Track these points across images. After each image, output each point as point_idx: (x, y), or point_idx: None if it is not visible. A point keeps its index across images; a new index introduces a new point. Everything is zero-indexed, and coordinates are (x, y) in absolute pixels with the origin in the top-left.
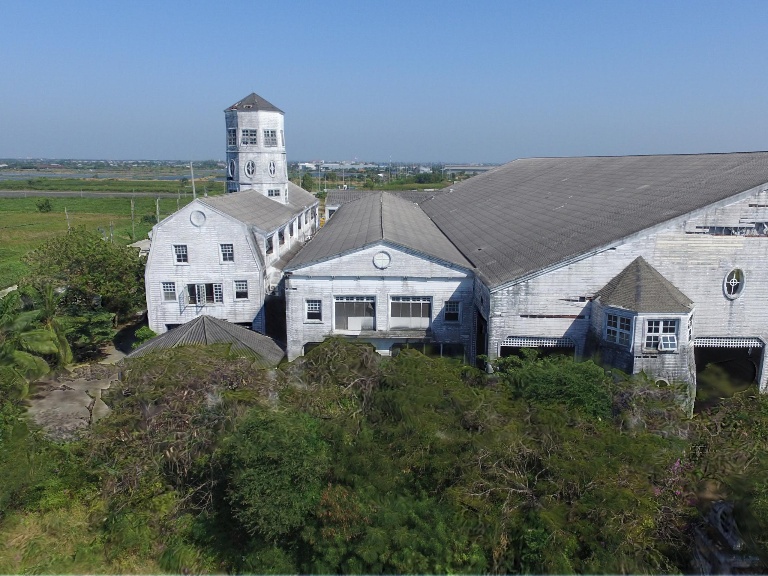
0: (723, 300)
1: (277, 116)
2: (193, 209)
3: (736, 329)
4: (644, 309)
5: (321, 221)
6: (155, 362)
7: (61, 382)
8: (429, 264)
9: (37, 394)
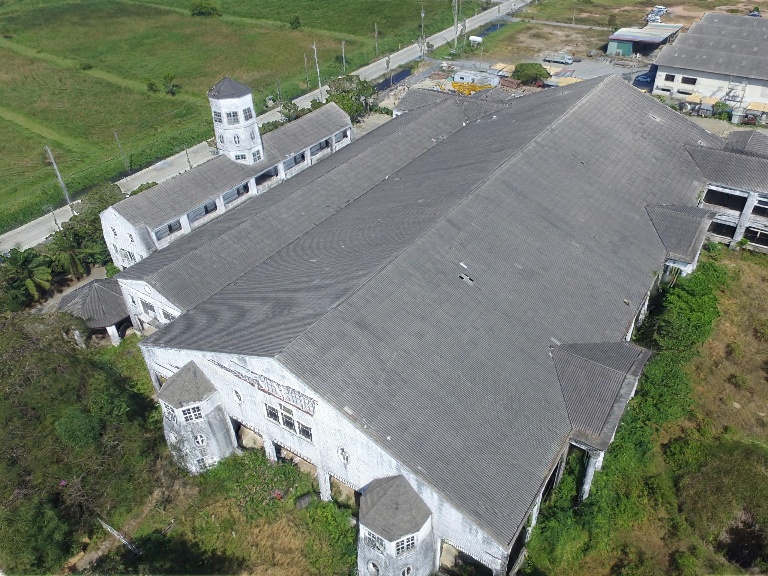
0: (236, 402)
1: (237, 101)
2: (111, 211)
3: (247, 420)
4: (161, 396)
5: (464, 86)
6: (8, 333)
7: (80, 281)
8: (167, 300)
9: (63, 288)
